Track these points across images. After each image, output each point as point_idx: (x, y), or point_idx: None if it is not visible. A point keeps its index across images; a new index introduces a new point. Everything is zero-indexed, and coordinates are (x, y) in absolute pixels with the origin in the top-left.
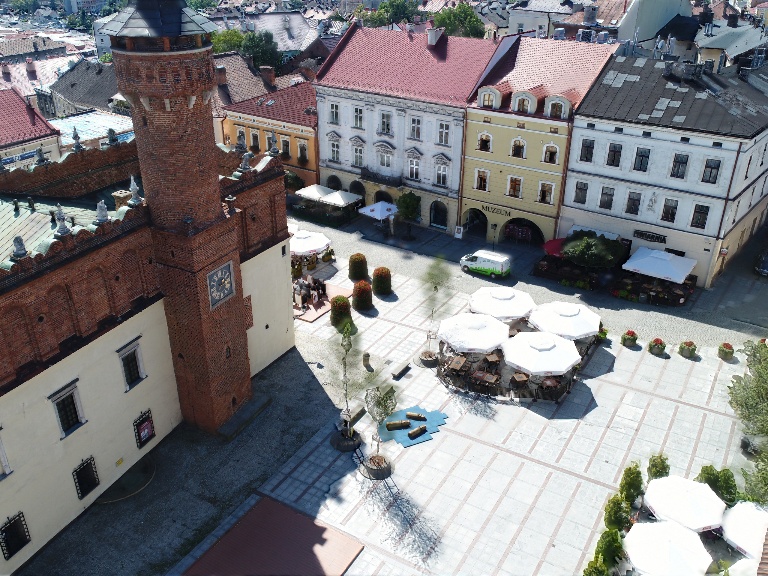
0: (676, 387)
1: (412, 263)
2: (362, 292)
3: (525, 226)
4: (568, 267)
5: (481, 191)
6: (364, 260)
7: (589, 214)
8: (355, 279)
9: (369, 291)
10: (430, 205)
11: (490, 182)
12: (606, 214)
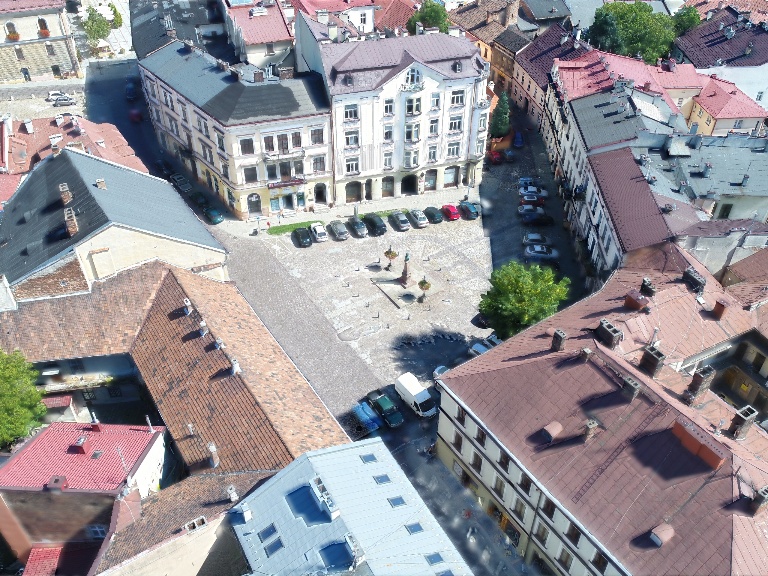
0: (130, 43)
1: None
2: None
3: None
4: None
5: None
6: None
7: None
8: None
9: None
10: None
11: None
12: None
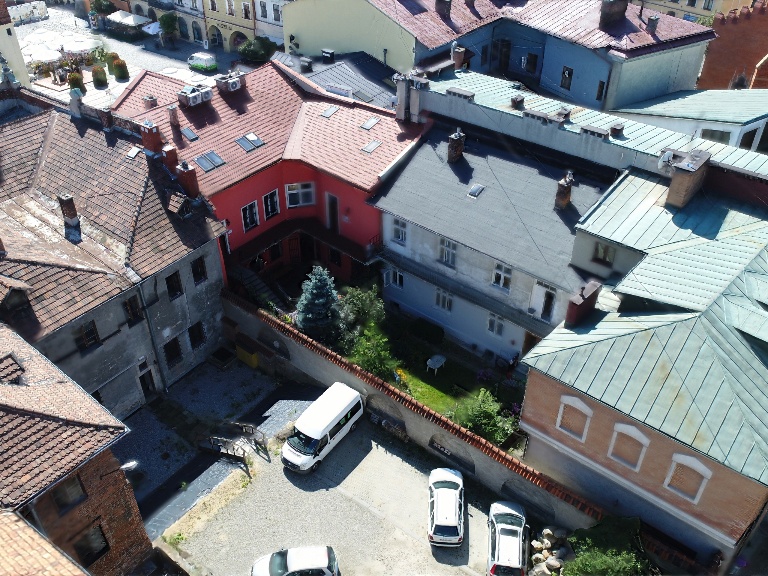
0: None
1: (160, 63)
2: (96, 73)
3: (245, 38)
4: (252, 64)
5: (214, 11)
6: (116, 57)
7: (270, 26)
8: (111, 71)
9: (101, 73)
10: (192, 25)
11: (217, 4)
12: (278, 25)
